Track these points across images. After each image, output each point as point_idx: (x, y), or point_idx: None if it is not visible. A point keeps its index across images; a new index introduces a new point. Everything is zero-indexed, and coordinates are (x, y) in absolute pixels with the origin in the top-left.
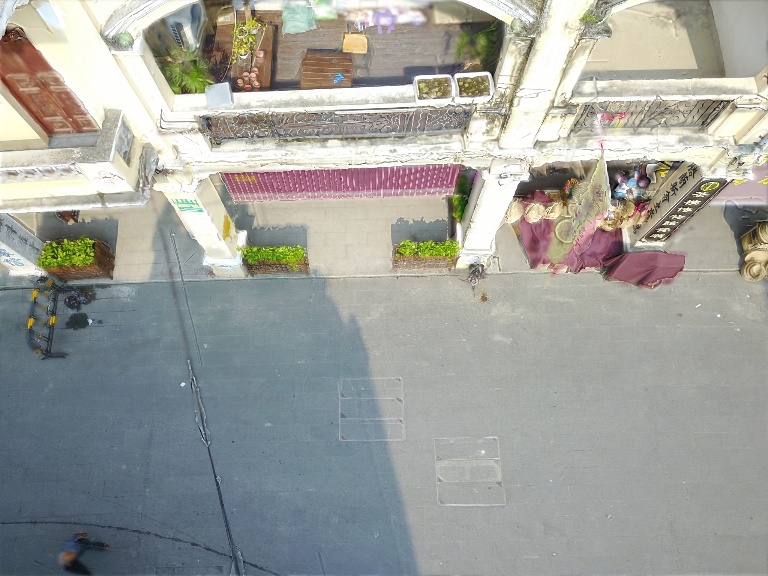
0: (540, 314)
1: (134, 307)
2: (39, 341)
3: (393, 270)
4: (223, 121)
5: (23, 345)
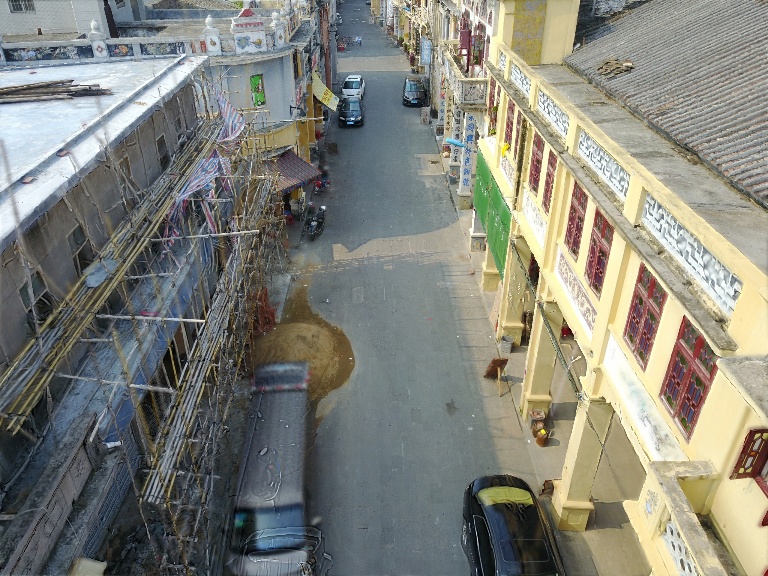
0: (402, 62)
1: None
2: None
3: None
4: (407, 4)
5: None
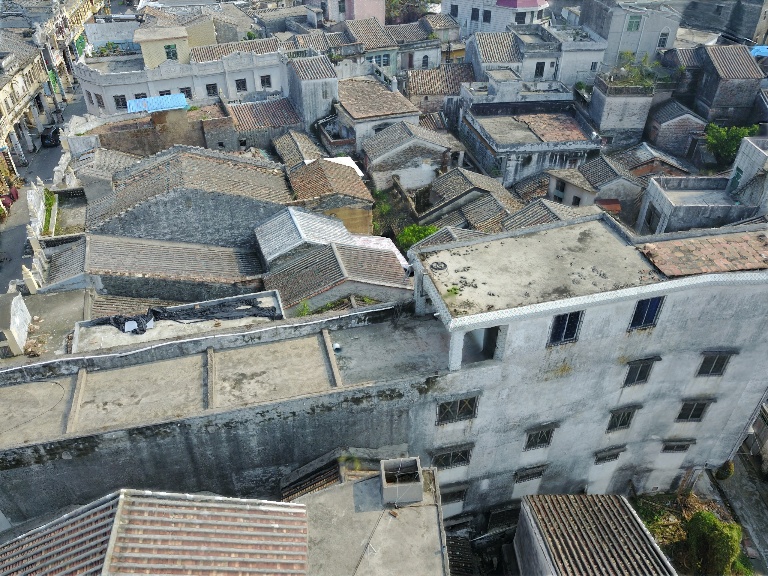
0: None
1: (2, 253)
2: (7, 260)
3: (4, 222)
4: None
5: (7, 265)
